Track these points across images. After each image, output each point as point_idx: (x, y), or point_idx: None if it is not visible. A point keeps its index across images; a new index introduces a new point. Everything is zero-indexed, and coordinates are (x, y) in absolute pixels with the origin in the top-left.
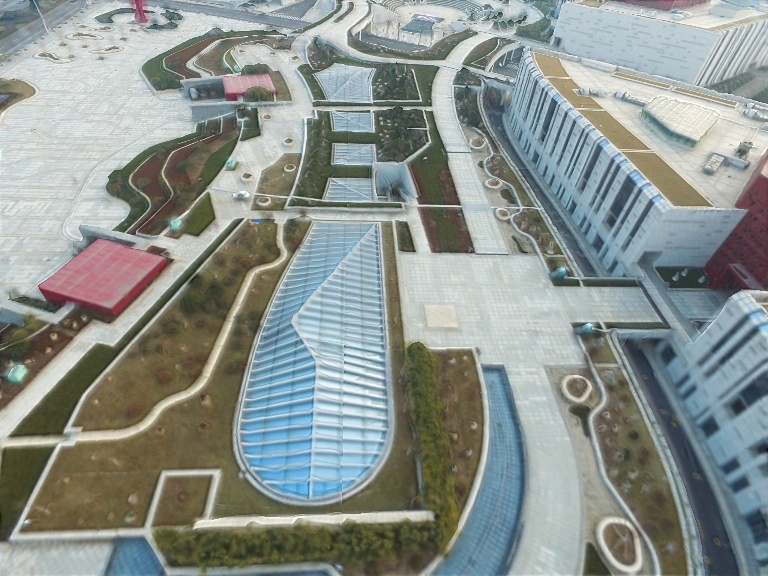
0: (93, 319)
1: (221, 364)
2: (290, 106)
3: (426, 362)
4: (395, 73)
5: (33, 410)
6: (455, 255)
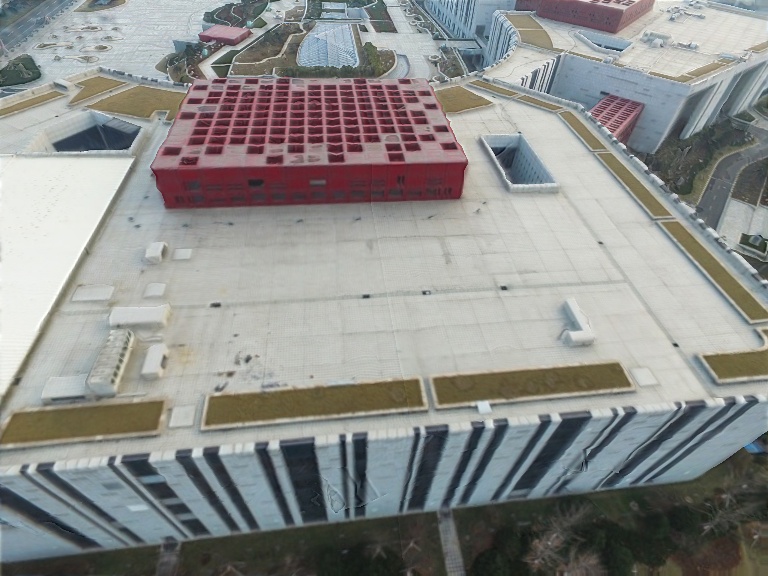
0: (226, 45)
1: None
2: None
3: (372, 46)
4: None
5: (216, 60)
6: (388, 33)
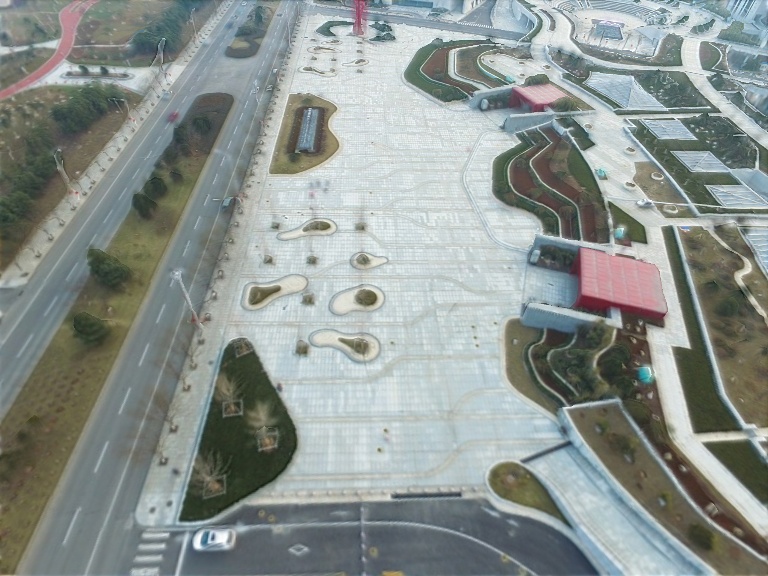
0: (646, 324)
1: None
2: (596, 115)
3: None
4: (659, 80)
5: (689, 409)
6: None
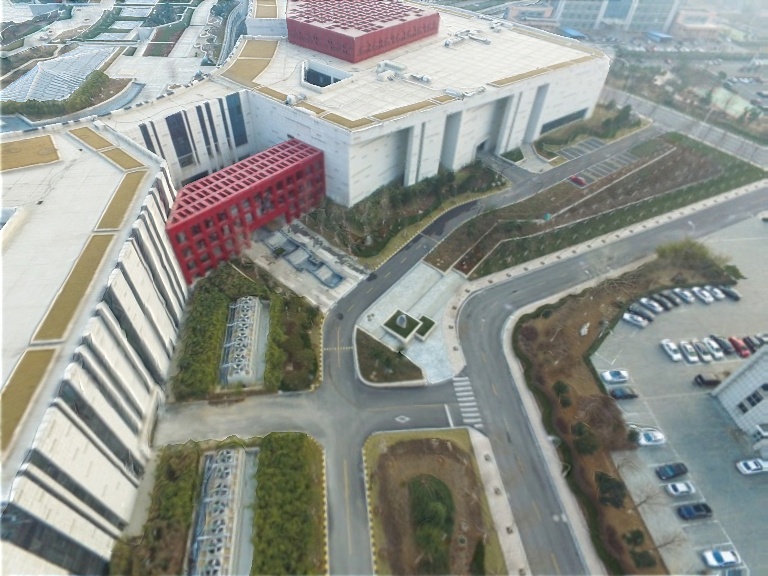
0: None
1: None
2: (98, 6)
3: (98, 74)
4: None
5: None
6: (155, 57)
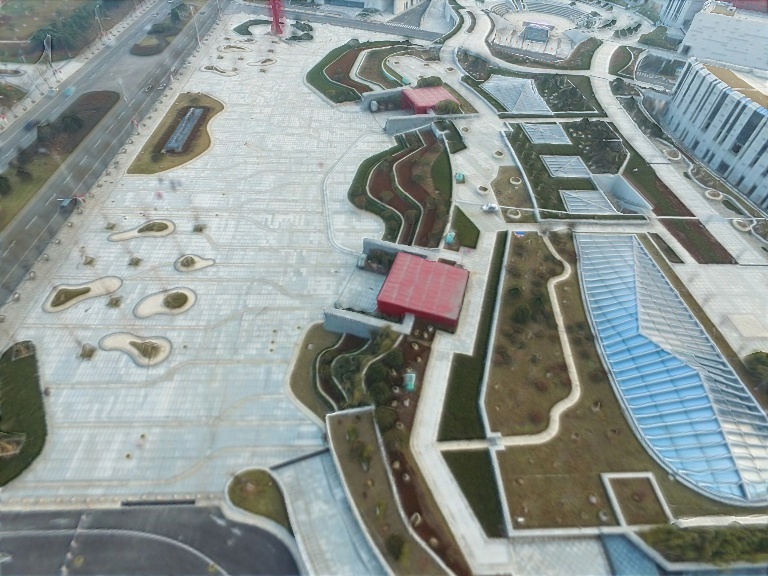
0: (437, 330)
1: (582, 373)
2: (478, 118)
3: None
4: (557, 84)
5: (442, 416)
6: (722, 266)
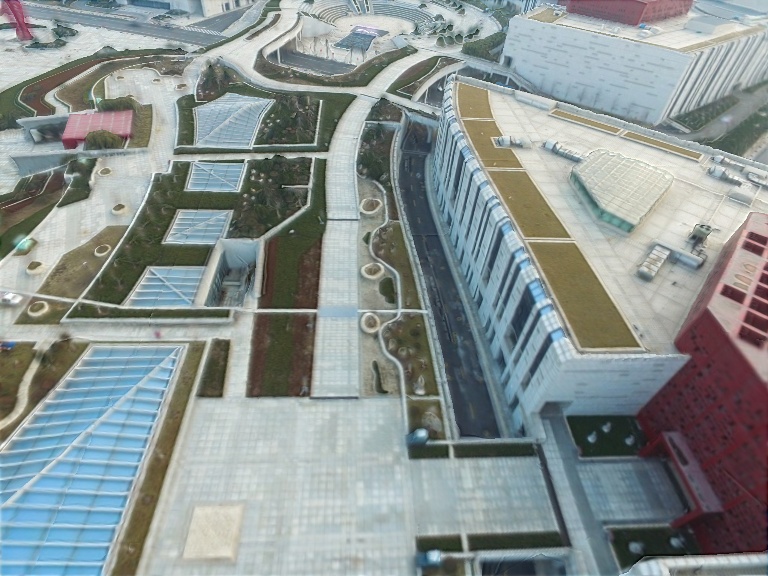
0: None
1: None
2: (144, 154)
3: None
4: (295, 106)
5: None
6: (278, 401)
